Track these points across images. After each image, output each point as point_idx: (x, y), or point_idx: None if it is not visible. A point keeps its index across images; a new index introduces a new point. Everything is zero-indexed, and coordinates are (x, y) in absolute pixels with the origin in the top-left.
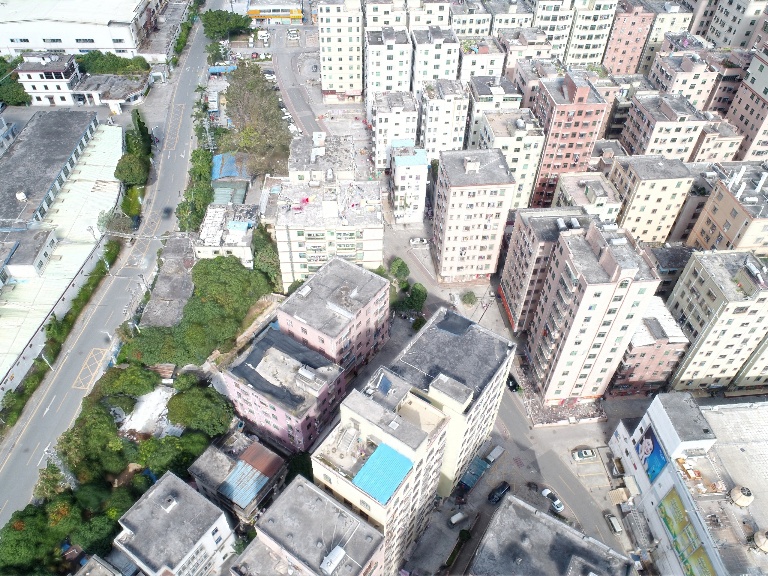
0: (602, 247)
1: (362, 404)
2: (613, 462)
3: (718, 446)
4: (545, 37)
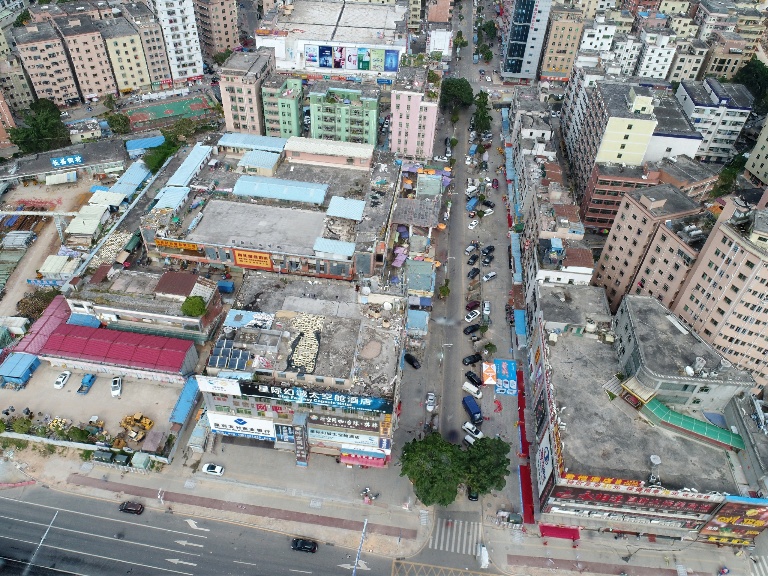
0: None
1: None
2: None
3: (298, 5)
4: None
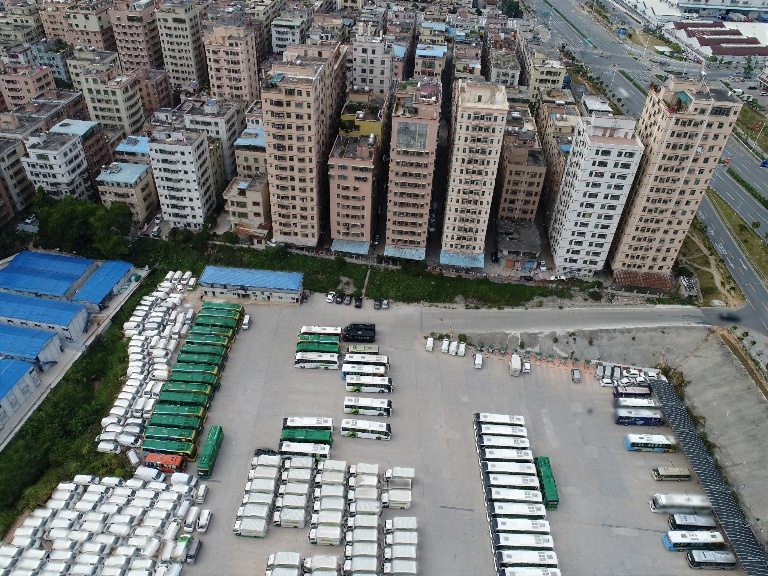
0: None
1: None
2: None
3: None
4: (221, 2)
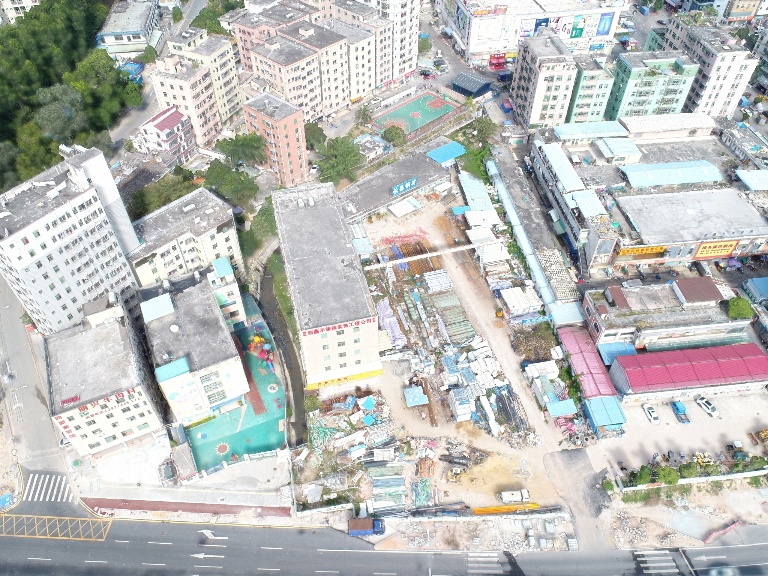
0: None
1: None
2: (434, 12)
3: None
4: None
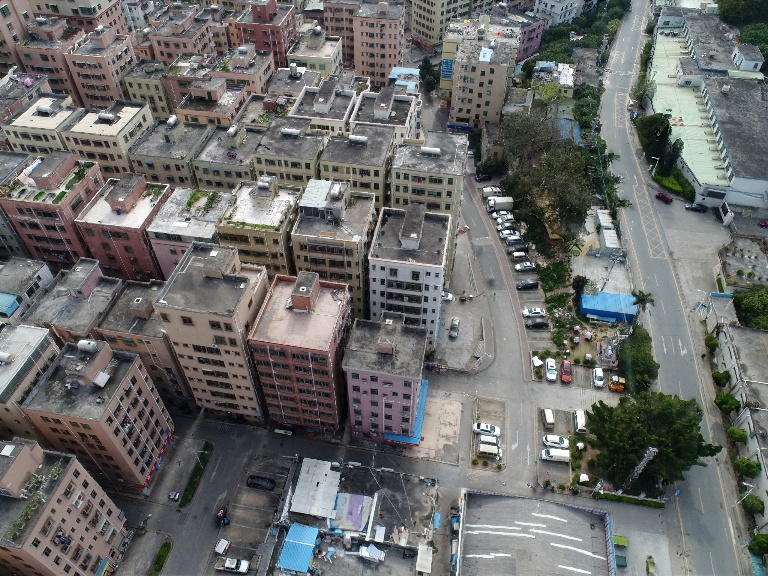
0: None
1: None
2: None
3: None
4: None
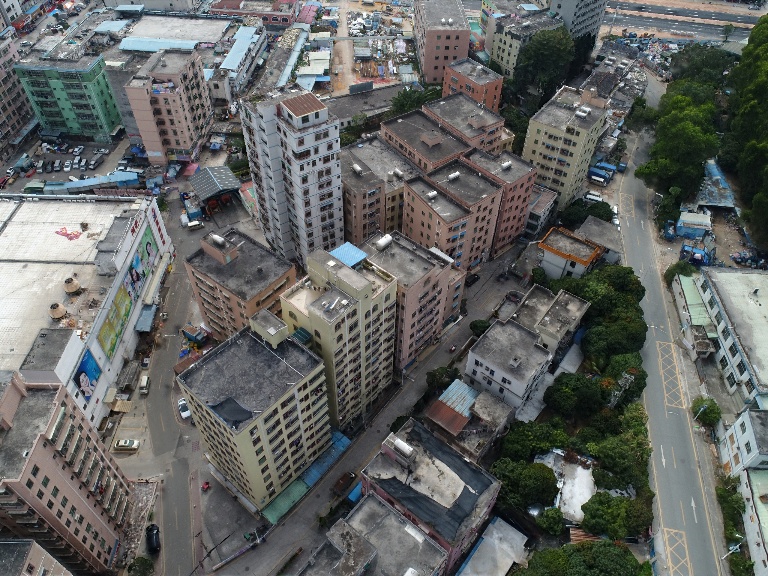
0: (2, 414)
1: (354, 280)
2: None
3: None
4: None
